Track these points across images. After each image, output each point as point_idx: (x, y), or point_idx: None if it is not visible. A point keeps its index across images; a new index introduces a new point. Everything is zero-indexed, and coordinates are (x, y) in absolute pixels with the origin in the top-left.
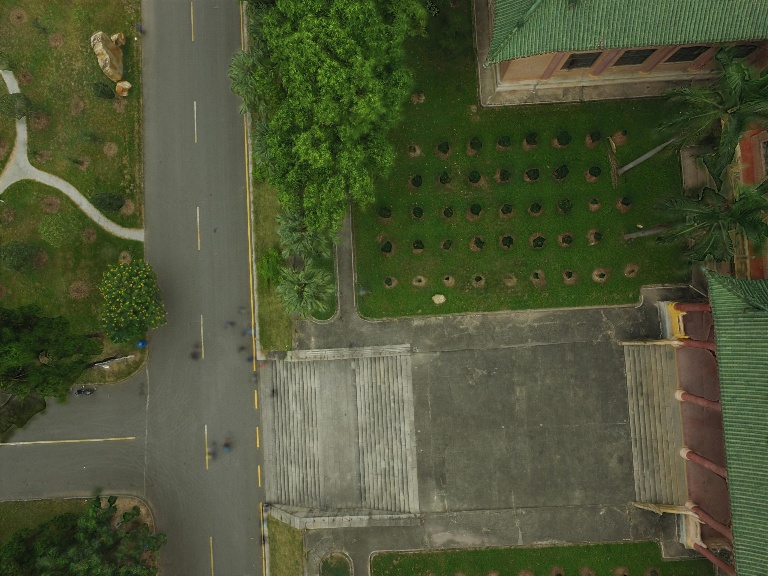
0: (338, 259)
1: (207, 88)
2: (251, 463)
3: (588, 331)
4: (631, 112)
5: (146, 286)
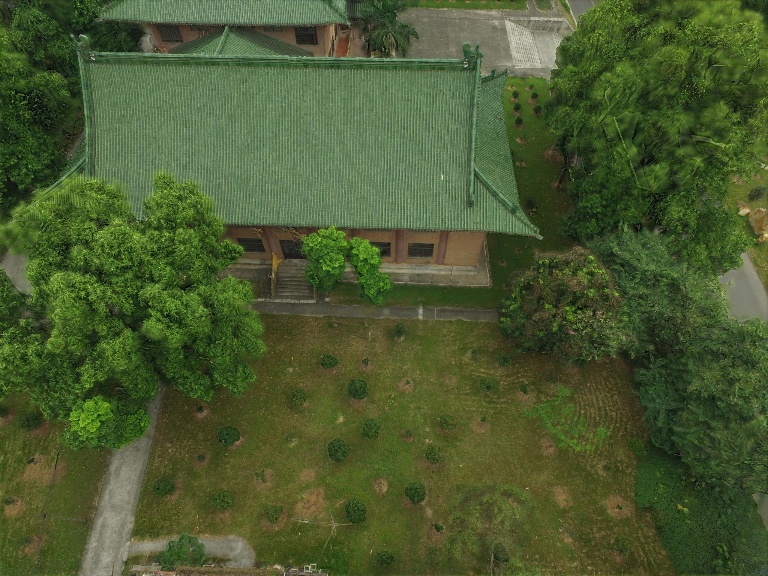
0: None
1: None
2: None
3: None
4: None
5: None
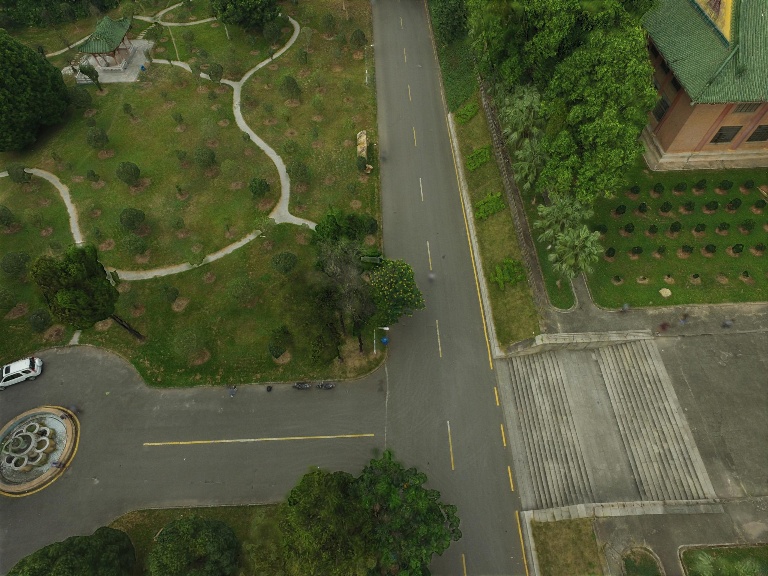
0: None
1: (429, 171)
2: (500, 464)
3: None
4: (766, 174)
5: None
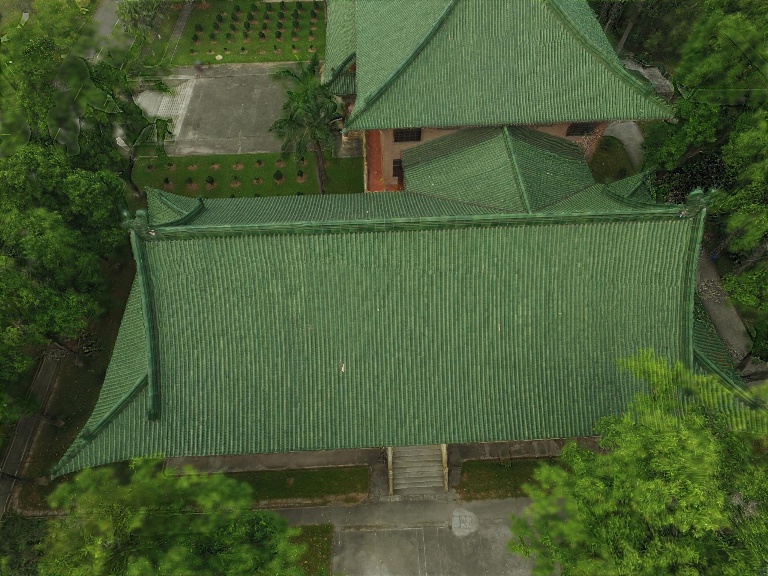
0: (168, 47)
1: None
2: None
3: None
4: None
5: None
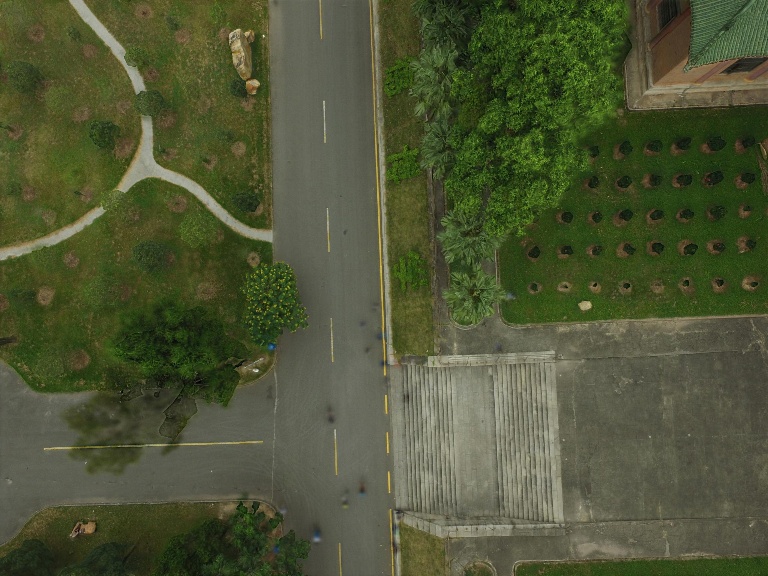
0: None
1: (336, 87)
2: (381, 469)
3: (737, 340)
4: None
5: (292, 289)
